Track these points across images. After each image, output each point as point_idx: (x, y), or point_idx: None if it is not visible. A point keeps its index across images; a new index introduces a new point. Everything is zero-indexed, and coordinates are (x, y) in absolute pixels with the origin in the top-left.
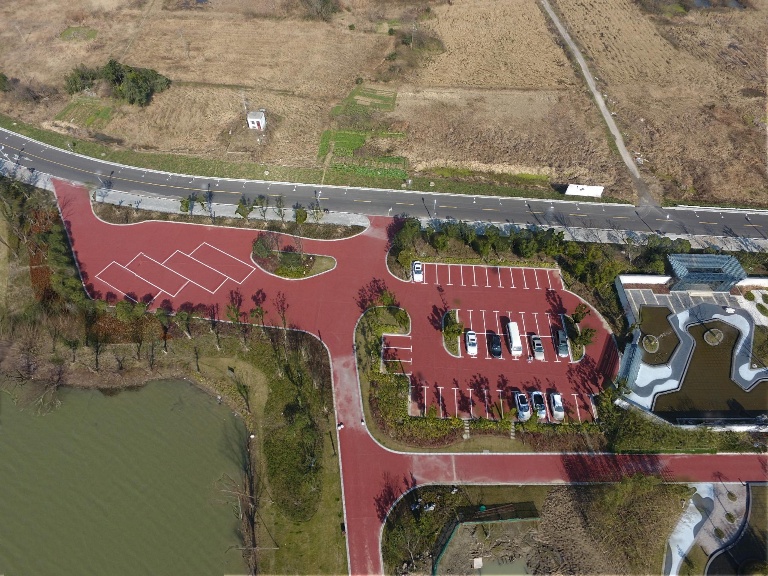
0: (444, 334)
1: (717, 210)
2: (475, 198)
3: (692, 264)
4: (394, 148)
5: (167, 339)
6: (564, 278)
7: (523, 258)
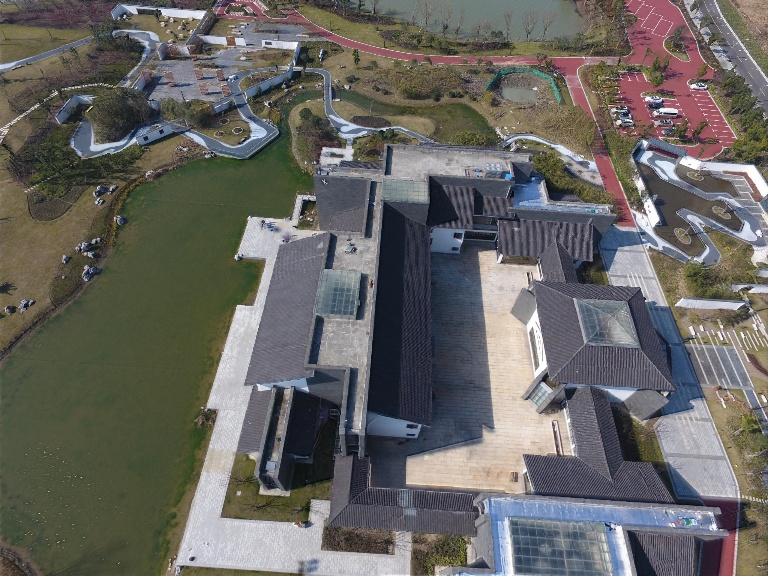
0: None
1: None
2: None
3: None
4: None
5: (608, 17)
6: None
7: (741, 127)
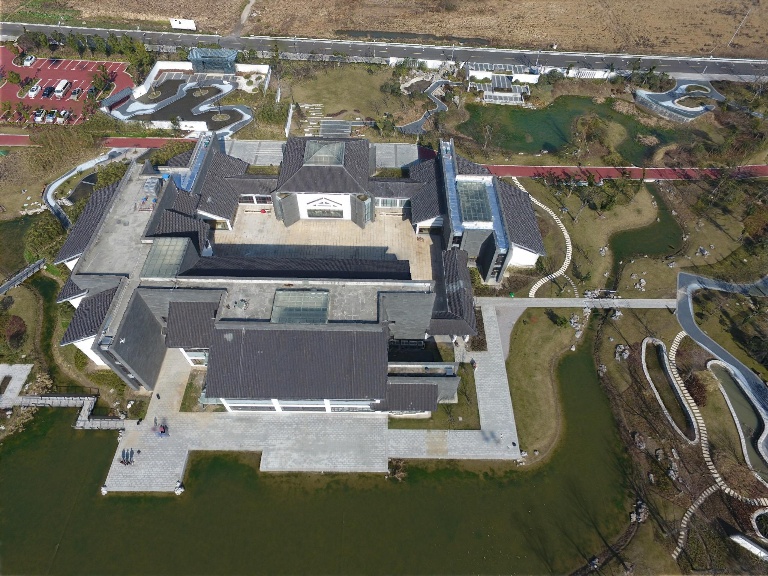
0: (8, 81)
1: (278, 39)
2: (110, 31)
3: (207, 54)
4: (75, 5)
5: None
6: (128, 66)
7: (105, 55)
